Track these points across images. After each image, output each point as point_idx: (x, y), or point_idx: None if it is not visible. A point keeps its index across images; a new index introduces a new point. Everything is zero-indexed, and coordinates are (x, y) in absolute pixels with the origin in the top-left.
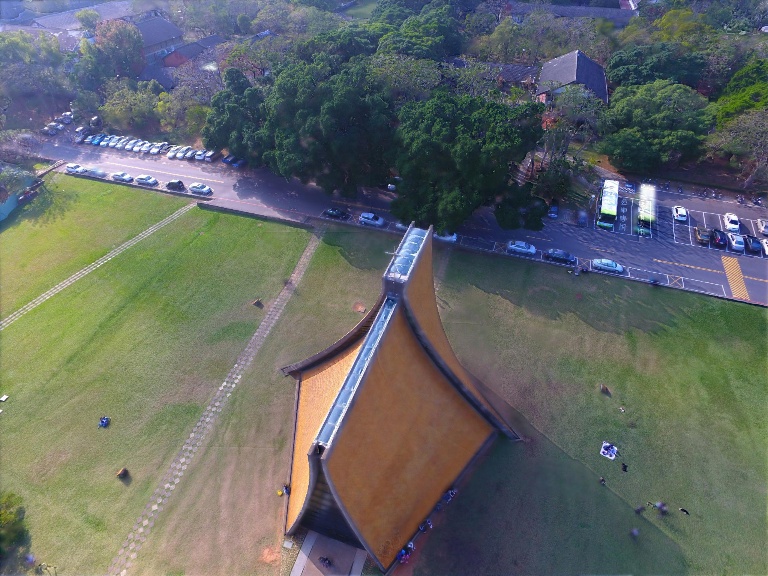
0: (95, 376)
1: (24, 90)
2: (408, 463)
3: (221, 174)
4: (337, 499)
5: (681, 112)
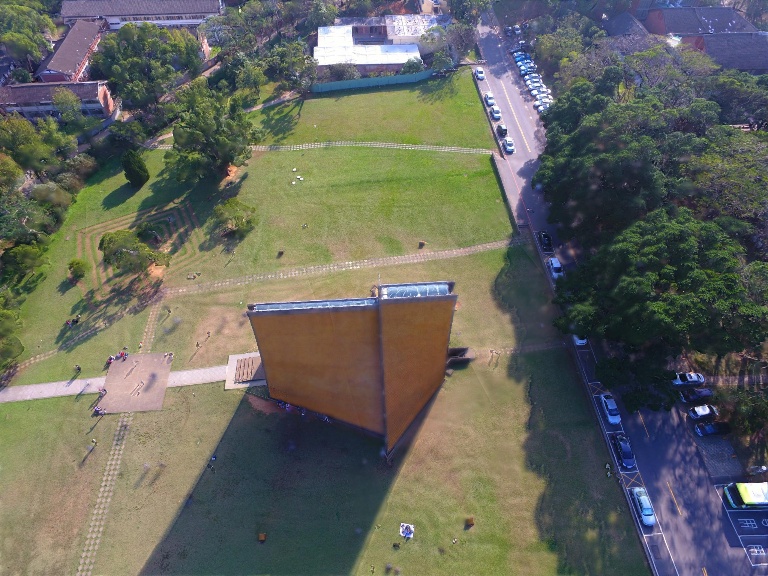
0: (329, 203)
1: None
2: (316, 377)
3: (539, 144)
4: None
5: None
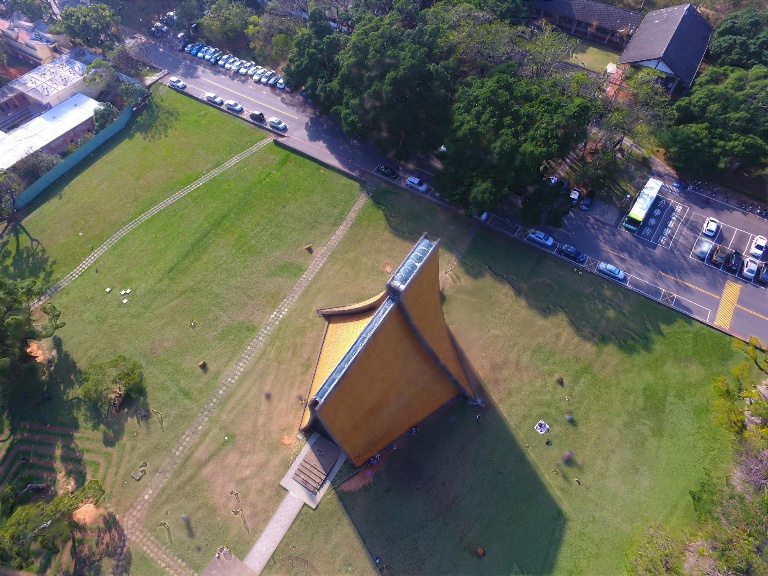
0: (187, 287)
1: None
2: (385, 408)
3: (297, 108)
4: (326, 428)
5: (767, 110)
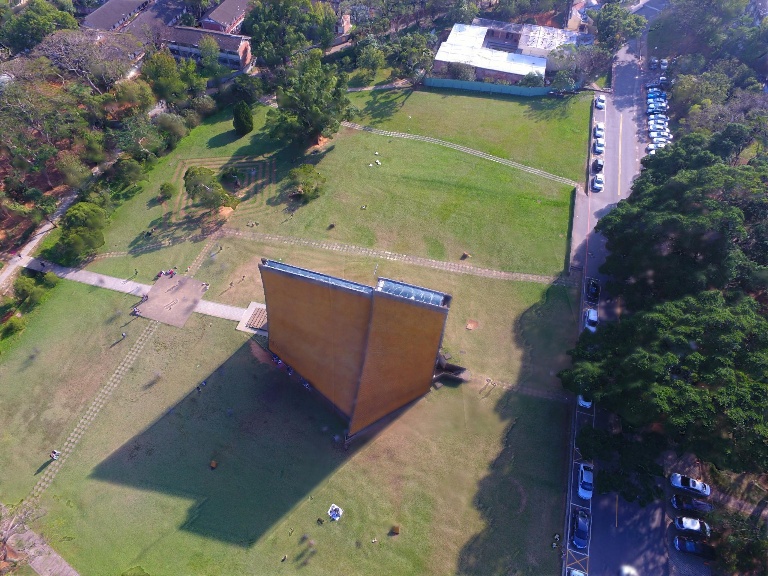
0: (394, 192)
1: (671, 25)
2: (308, 344)
3: None
4: None
5: None
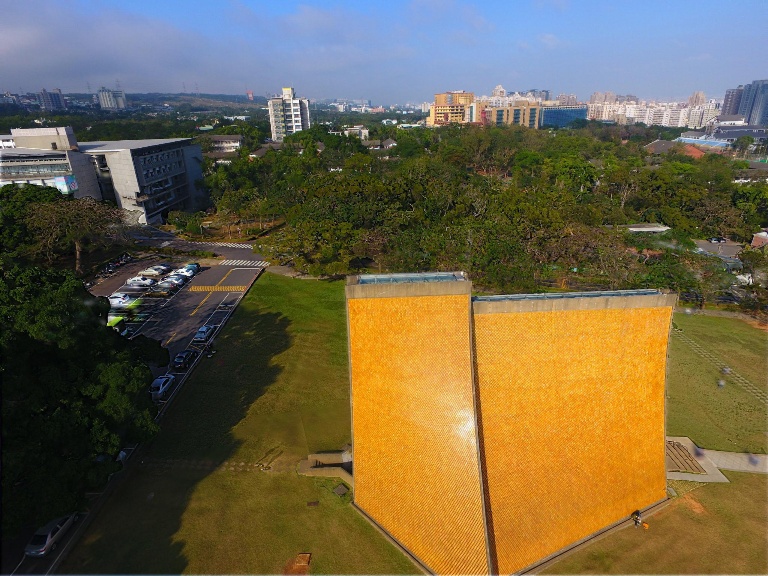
0: None
1: None
2: None
3: None
4: None
5: None
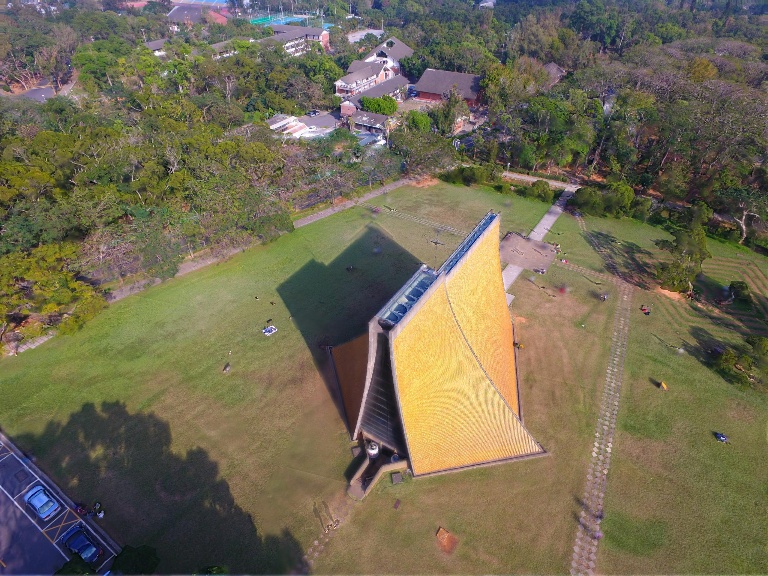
0: None
1: None
2: None
3: None
4: None
5: None
